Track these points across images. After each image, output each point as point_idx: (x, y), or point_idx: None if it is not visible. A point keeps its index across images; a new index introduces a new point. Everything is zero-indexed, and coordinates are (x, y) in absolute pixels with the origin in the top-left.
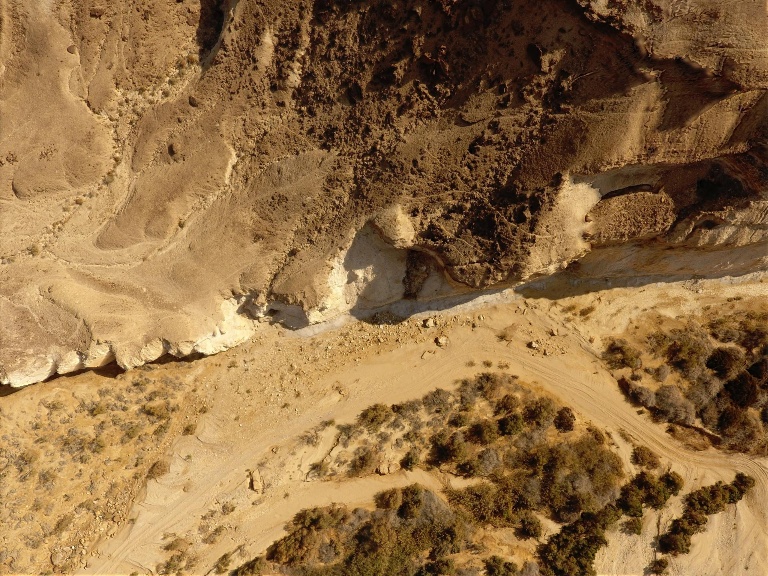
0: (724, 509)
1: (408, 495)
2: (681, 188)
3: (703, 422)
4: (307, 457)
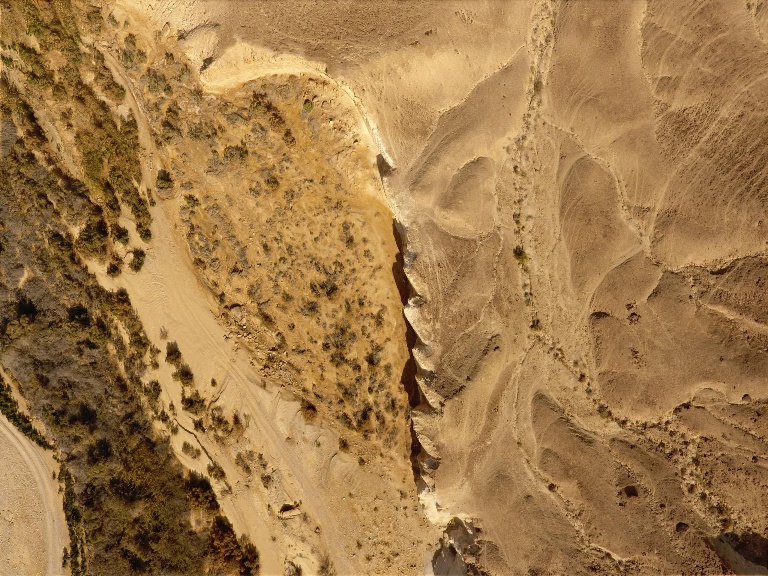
0: None
1: None
2: None
3: None
4: (308, 564)
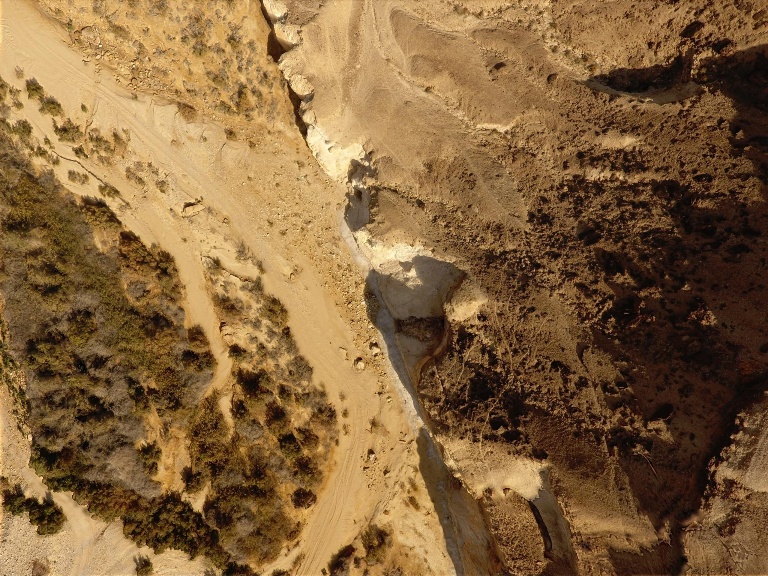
0: None
1: (205, 358)
2: None
3: None
4: (225, 253)
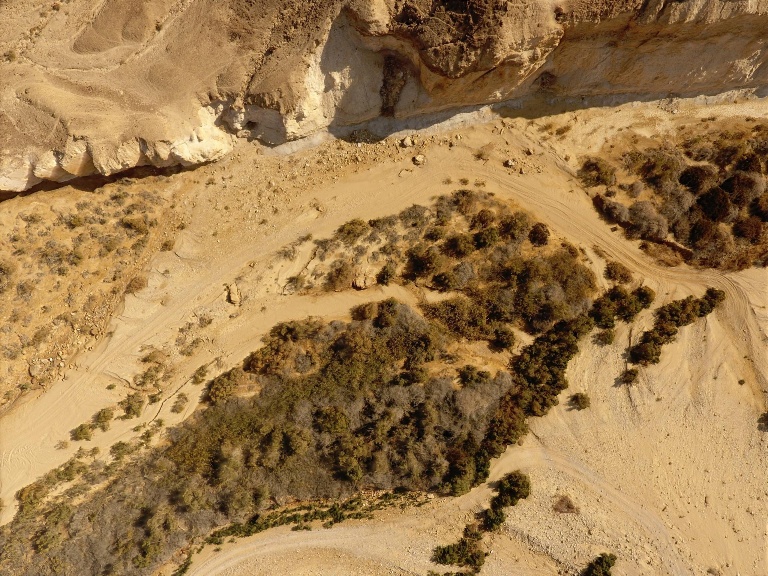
0: (694, 320)
1: (384, 307)
2: None
3: (675, 236)
4: (284, 271)
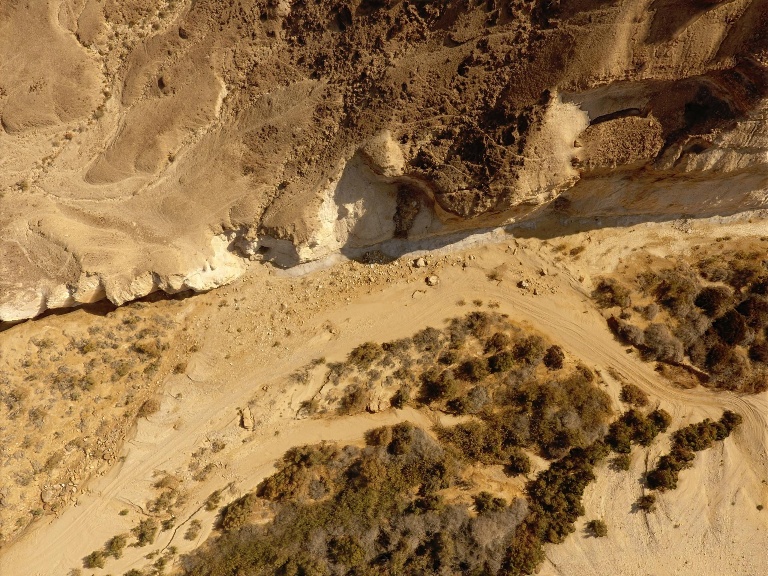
0: (711, 445)
1: (398, 432)
2: (669, 111)
3: (691, 360)
4: (297, 395)
